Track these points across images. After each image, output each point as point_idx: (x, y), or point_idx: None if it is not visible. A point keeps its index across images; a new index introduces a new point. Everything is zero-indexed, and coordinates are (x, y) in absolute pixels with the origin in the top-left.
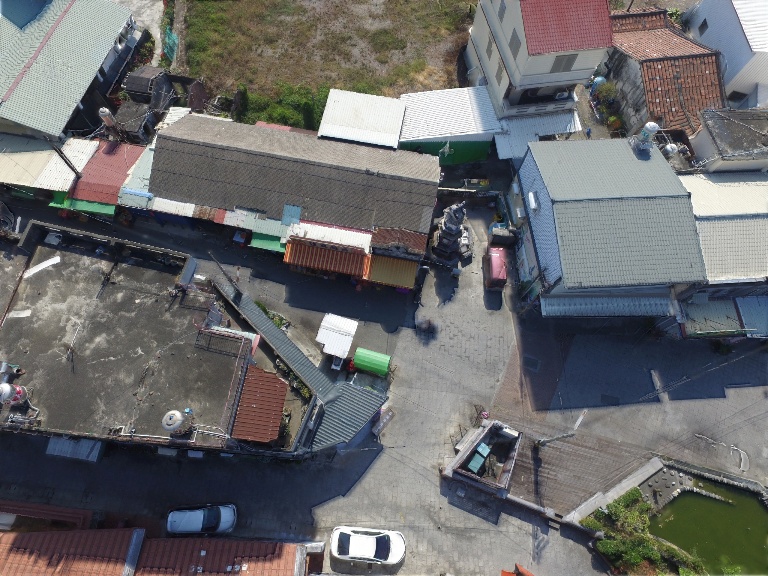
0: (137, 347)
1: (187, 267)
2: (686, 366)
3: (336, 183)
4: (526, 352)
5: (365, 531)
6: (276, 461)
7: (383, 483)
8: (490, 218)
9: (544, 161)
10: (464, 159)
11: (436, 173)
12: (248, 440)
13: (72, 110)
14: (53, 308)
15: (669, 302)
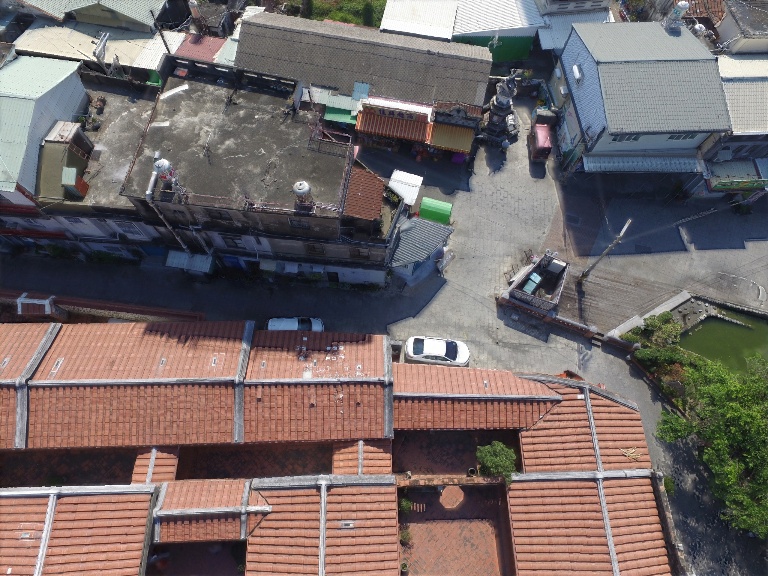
0: (260, 148)
1: (298, 89)
2: (710, 224)
3: (401, 62)
4: (568, 211)
5: (436, 338)
6: (354, 290)
7: (447, 308)
8: (533, 106)
9: (587, 36)
10: (508, 57)
11: (488, 56)
12: (355, 220)
13: (162, 5)
14: (187, 120)
15: (696, 161)
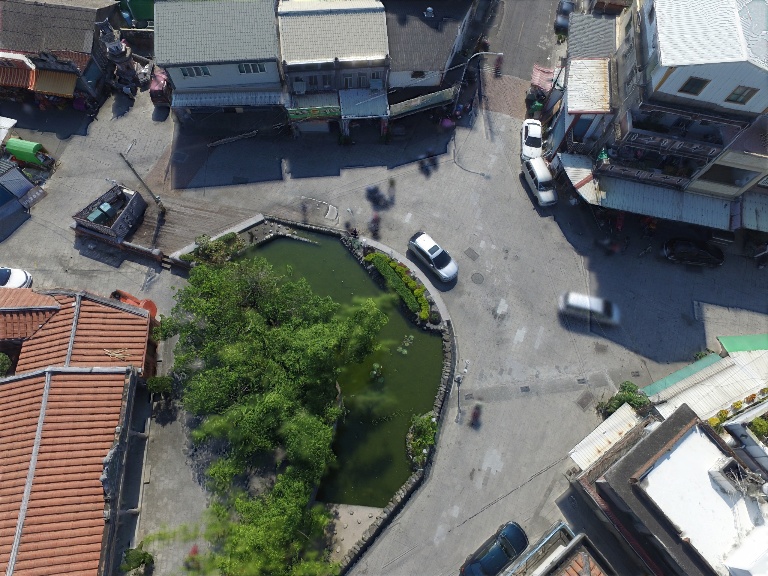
0: None
1: None
2: (313, 155)
3: (10, 14)
4: (178, 149)
5: None
6: None
7: (25, 242)
8: None
9: None
10: None
11: (102, 6)
12: None
13: None
14: None
15: (281, 95)
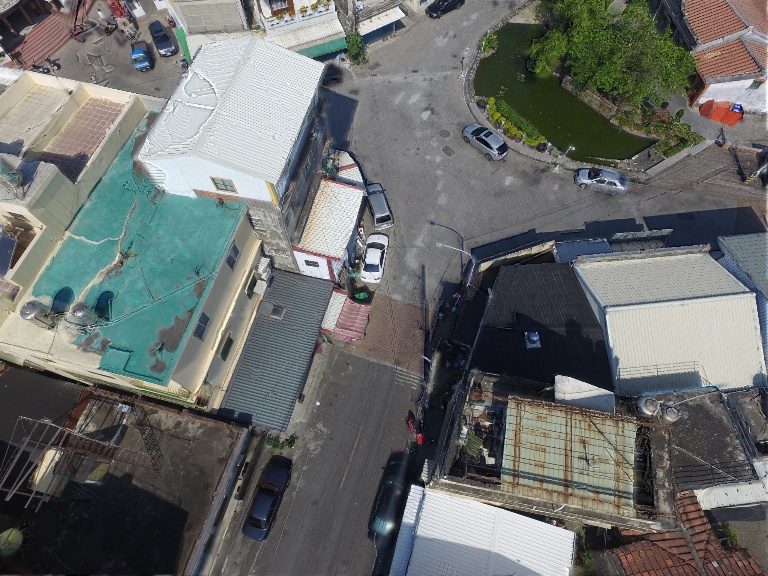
0: None
1: None
2: None
3: None
4: None
5: None
6: None
7: None
8: None
9: None
10: None
11: None
12: None
13: None
14: None
15: None
